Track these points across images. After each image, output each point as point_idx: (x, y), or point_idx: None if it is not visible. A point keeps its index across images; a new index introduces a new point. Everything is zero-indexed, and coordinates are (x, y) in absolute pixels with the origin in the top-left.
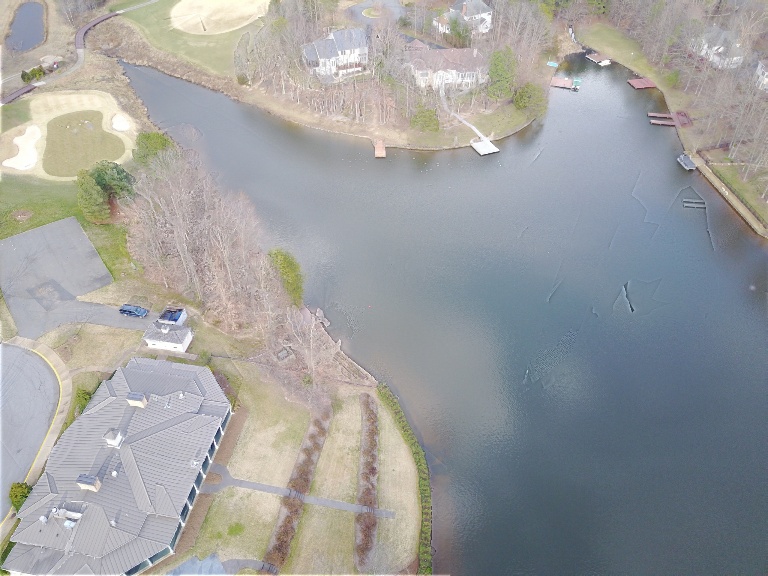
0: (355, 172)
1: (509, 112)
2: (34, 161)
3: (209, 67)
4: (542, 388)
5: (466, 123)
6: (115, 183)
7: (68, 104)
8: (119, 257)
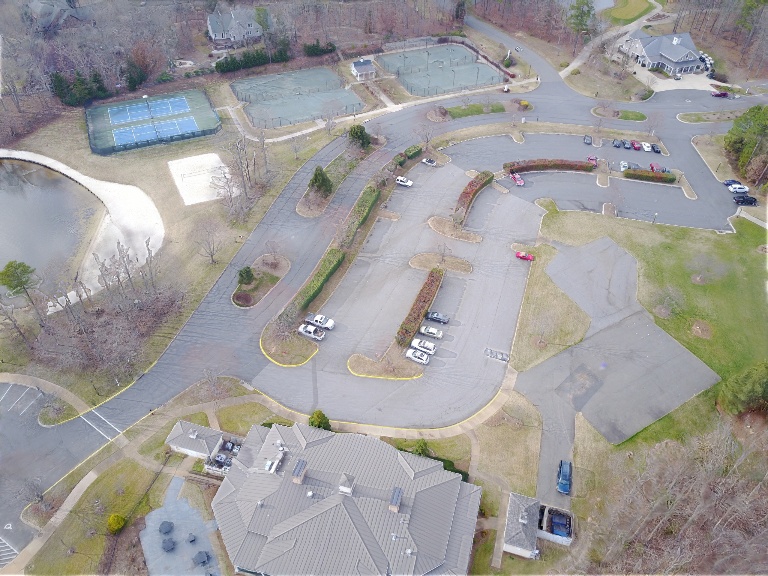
0: None
1: None
2: None
3: None
4: None
5: None
6: None
7: None
8: None
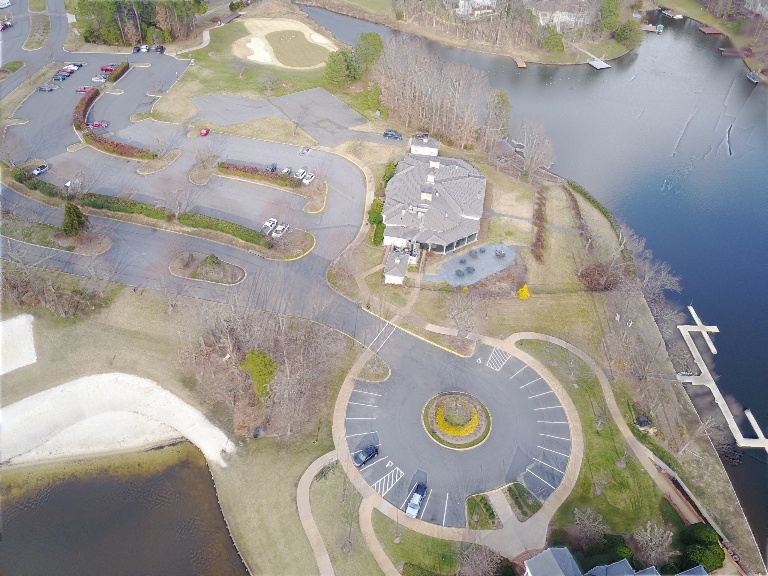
0: (497, 82)
1: (611, 44)
2: (269, 58)
3: (368, 8)
4: (675, 193)
5: (581, 49)
6: (353, 63)
7: (273, 26)
8: (365, 110)
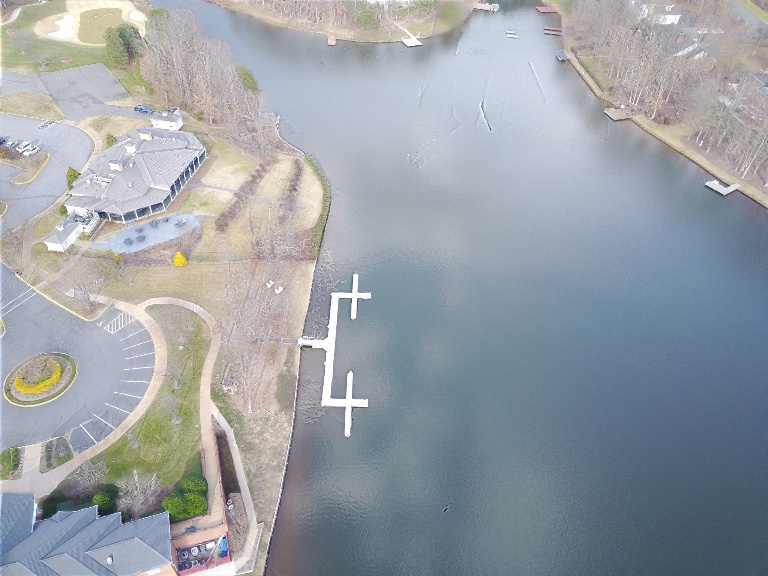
0: (314, 60)
1: None
2: (71, 34)
3: None
4: (418, 168)
5: (401, 27)
6: (132, 39)
7: (95, 4)
8: (134, 85)
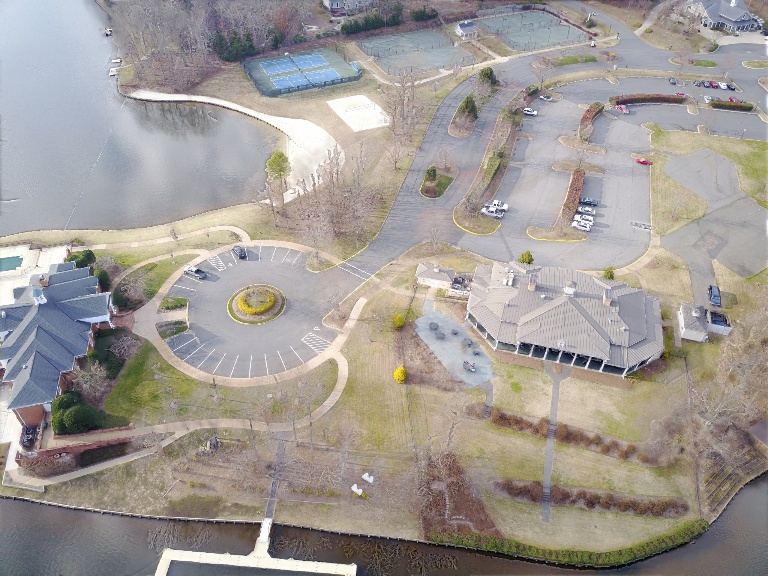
0: None
1: None
2: None
3: None
4: None
5: None
6: None
7: None
8: None
